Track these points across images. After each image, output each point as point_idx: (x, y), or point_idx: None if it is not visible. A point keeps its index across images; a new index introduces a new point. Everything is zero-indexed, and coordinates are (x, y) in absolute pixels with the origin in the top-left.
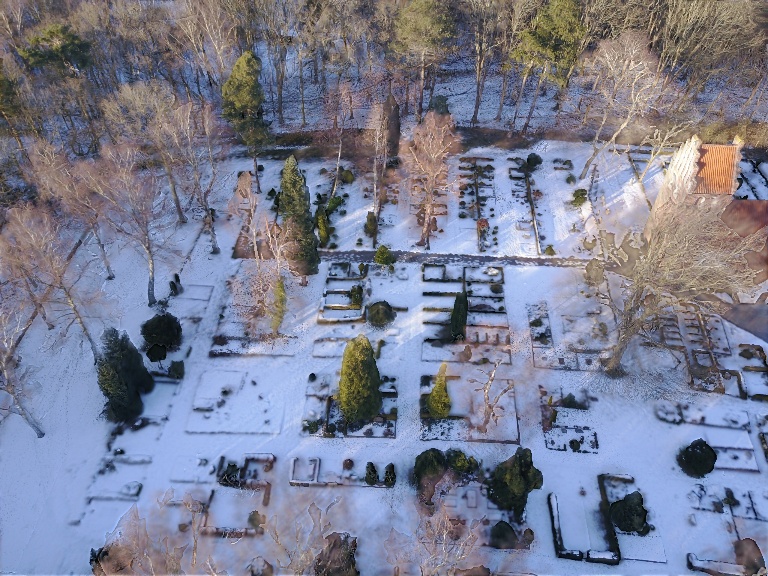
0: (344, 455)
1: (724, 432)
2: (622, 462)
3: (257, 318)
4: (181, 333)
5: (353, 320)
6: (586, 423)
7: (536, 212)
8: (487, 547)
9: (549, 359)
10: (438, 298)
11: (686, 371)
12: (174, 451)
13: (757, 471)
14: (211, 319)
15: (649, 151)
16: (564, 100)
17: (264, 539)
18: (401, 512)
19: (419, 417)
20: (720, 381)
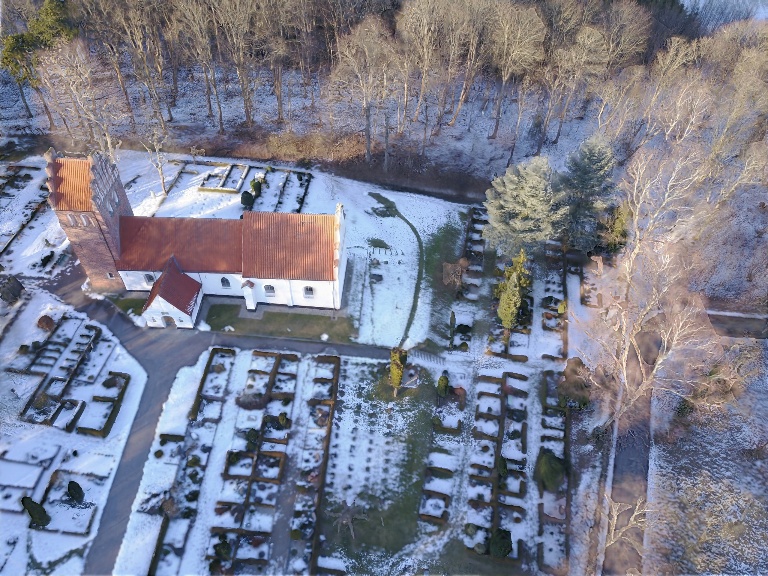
0: None
1: (18, 468)
2: None
3: None
4: None
5: None
6: None
7: (29, 225)
8: None
9: None
10: None
11: (28, 400)
12: None
13: (19, 512)
14: None
15: (207, 162)
16: (180, 107)
17: None
18: None
19: None
20: (51, 412)
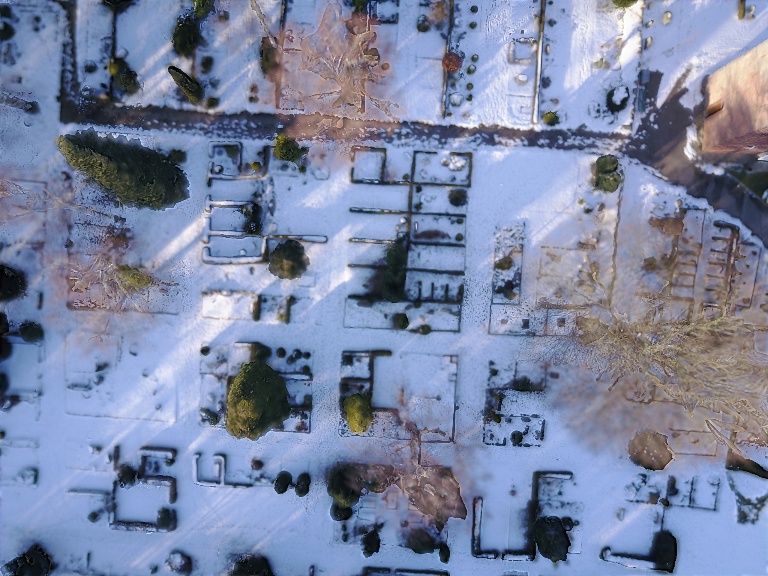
0: (252, 452)
1: (696, 411)
2: (565, 454)
3: (119, 251)
4: (19, 283)
5: (251, 262)
6: (536, 409)
7: (547, 17)
8: (403, 548)
9: (510, 322)
10: (371, 216)
11: None
12: (60, 433)
13: (713, 456)
14: (56, 244)
15: None
16: None
17: (178, 532)
18: (316, 514)
19: (338, 407)
20: None
